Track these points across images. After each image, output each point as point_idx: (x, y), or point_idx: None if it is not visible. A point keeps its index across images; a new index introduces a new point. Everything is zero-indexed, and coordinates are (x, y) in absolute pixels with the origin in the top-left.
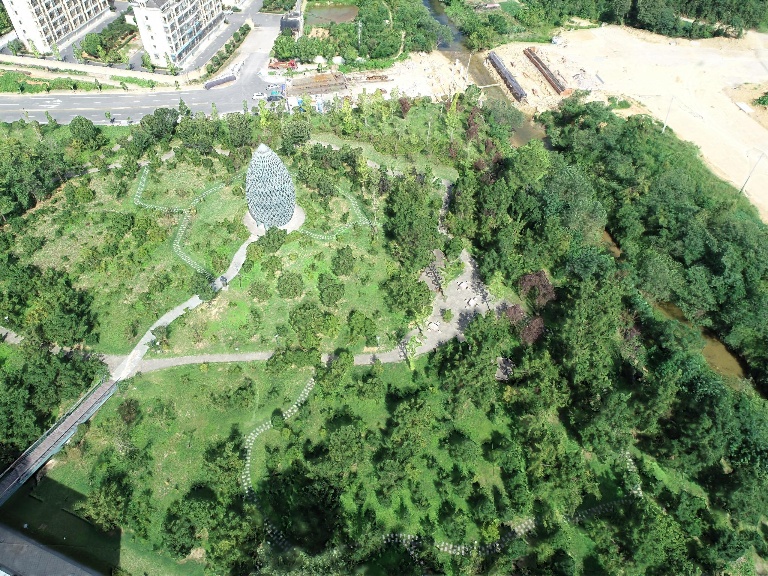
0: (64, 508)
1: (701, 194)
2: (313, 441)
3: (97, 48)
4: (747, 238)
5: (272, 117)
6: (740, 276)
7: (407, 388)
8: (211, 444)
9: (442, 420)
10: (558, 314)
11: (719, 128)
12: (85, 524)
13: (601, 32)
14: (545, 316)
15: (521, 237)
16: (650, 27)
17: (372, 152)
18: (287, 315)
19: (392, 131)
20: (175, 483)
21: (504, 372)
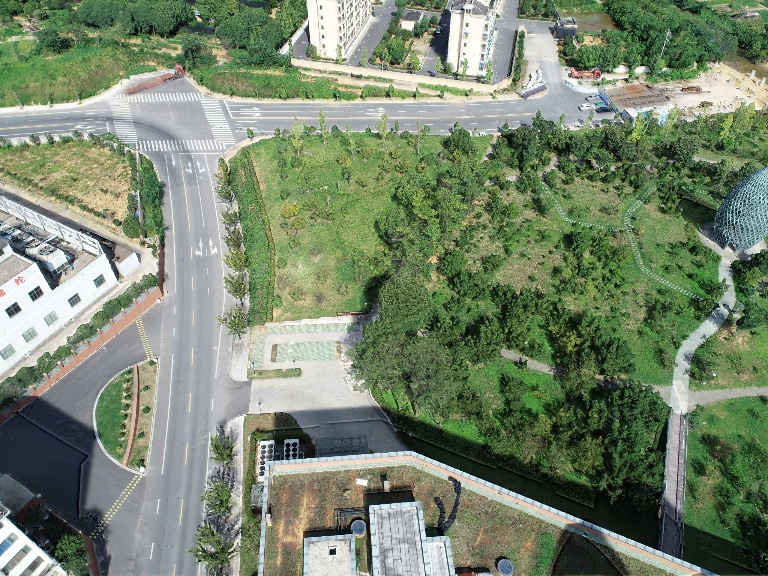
0: (714, 554)
1: None
2: None
3: None
4: None
5: None
6: None
7: None
8: None
9: None
10: None
11: None
12: (750, 573)
13: None
14: None
15: None
16: None
17: None
18: None
19: None
20: None
21: None
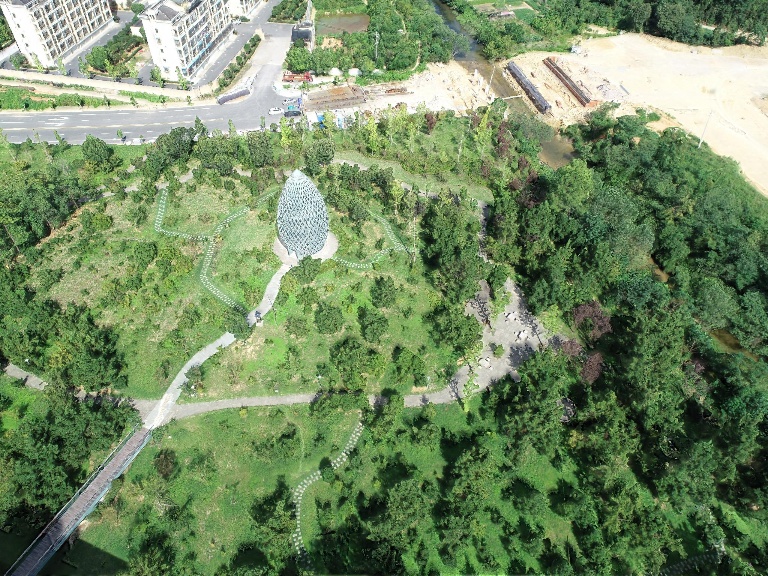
0: (101, 575)
1: (748, 214)
2: (366, 493)
3: (104, 62)
4: None
5: (292, 134)
6: None
7: (462, 432)
8: (257, 499)
9: (503, 467)
10: (615, 347)
11: (752, 141)
12: None
13: (620, 40)
14: (600, 349)
15: (567, 263)
16: (670, 35)
17: (400, 171)
18: (327, 352)
19: (419, 148)
20: (221, 544)
21: (564, 413)
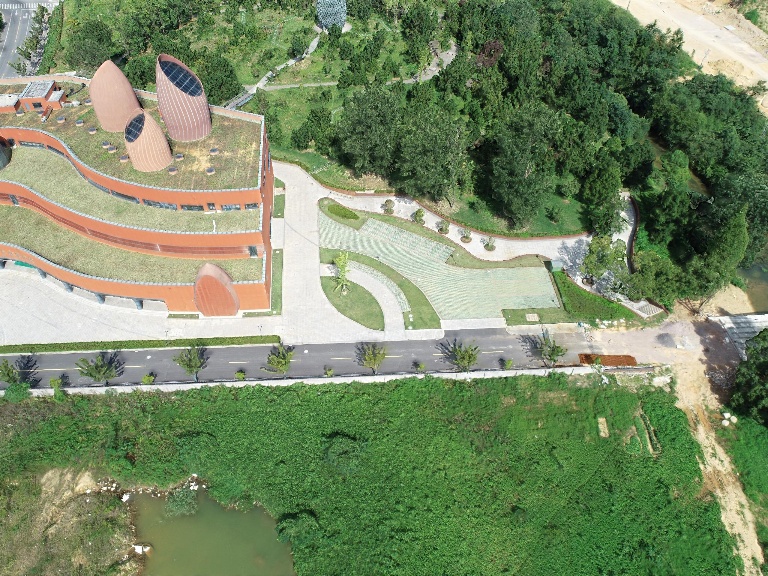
0: None
1: (603, 13)
2: None
3: None
4: (622, 23)
5: None
6: (617, 46)
7: None
8: None
9: None
10: None
11: None
12: None
13: None
14: None
15: None
16: None
17: (391, 3)
18: (346, 67)
19: None
20: (293, 128)
21: None
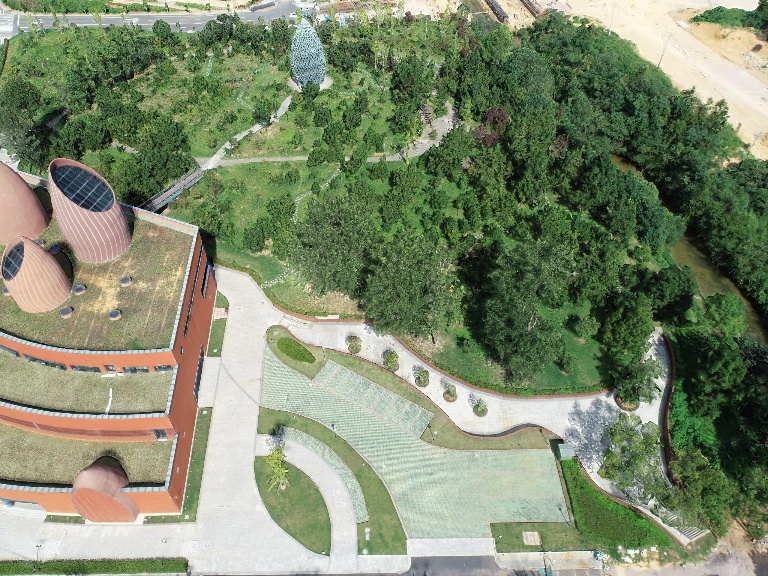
0: None
1: (629, 70)
2: None
3: None
4: (652, 88)
5: None
6: (647, 116)
7: None
8: None
9: None
10: None
11: (659, 38)
12: None
13: None
14: None
15: (490, 92)
16: None
17: None
18: (321, 136)
19: (399, 35)
20: None
21: None
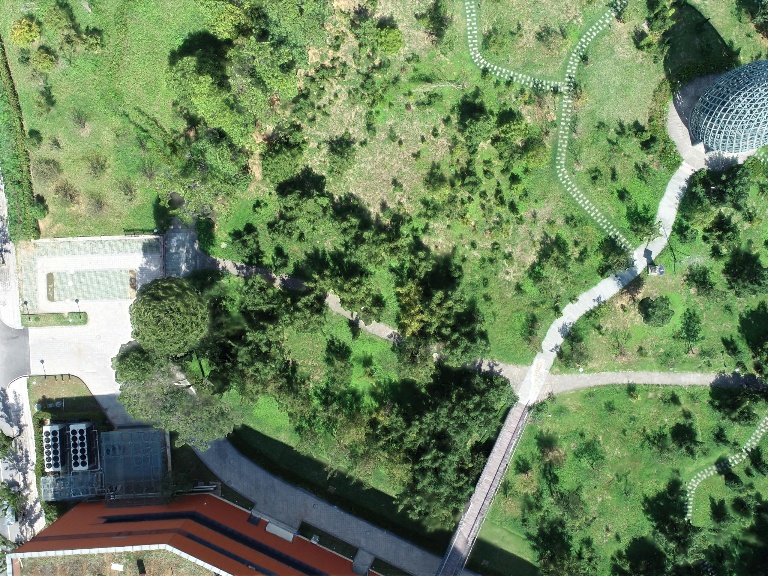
0: (503, 548)
1: None
2: (763, 494)
3: None
4: None
5: None
6: None
7: None
8: (649, 491)
9: None
10: None
11: None
12: (529, 565)
13: None
14: None
15: None
16: None
17: None
18: (737, 319)
19: None
20: (615, 531)
21: None
